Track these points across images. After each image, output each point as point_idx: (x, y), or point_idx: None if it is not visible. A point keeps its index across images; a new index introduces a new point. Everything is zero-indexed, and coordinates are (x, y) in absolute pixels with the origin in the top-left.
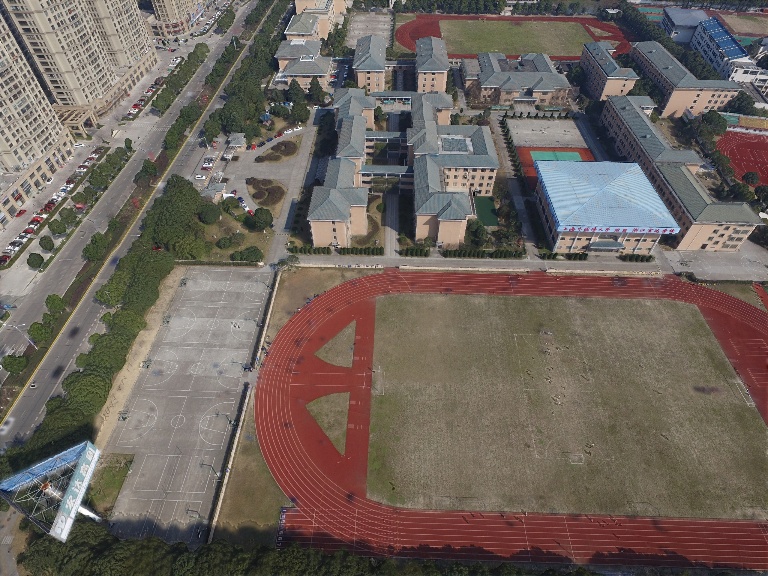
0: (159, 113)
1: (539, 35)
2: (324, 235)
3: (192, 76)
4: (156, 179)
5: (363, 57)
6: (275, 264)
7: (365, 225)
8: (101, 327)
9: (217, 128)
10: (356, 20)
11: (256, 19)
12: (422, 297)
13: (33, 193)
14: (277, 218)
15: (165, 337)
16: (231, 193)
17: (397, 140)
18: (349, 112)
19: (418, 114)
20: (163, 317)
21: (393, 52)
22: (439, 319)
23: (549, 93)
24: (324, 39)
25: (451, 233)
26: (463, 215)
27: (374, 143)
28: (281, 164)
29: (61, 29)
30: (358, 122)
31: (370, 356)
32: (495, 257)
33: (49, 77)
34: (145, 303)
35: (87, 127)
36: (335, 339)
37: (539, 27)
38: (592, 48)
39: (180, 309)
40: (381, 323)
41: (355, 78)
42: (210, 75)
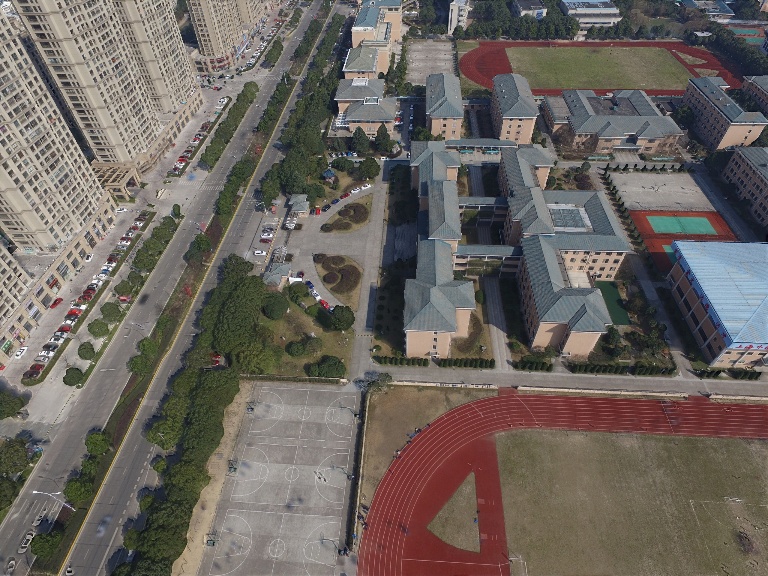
0: (208, 167)
1: (622, 64)
2: (421, 344)
3: (241, 120)
4: (209, 255)
5: (438, 101)
6: (360, 380)
7: (467, 326)
8: (152, 475)
9: (276, 189)
10: (413, 49)
11: (306, 51)
12: (554, 435)
13: (70, 275)
14: (355, 311)
15: (233, 494)
16: (298, 276)
17: (491, 207)
18: (433, 174)
19: (515, 176)
20: (228, 461)
21: (464, 89)
22: (583, 472)
23: (657, 140)
24: (383, 74)
25: (582, 344)
26: (602, 325)
27: (463, 210)
28: (352, 234)
29: (104, 81)
30: (448, 190)
31: (502, 533)
32: (637, 373)
33: (89, 133)
34: (208, 448)
35: (129, 186)
36: (451, 503)
37: (620, 54)
38: (702, 85)
39: (249, 449)
40: (508, 477)
41: (428, 124)
42: (262, 120)
